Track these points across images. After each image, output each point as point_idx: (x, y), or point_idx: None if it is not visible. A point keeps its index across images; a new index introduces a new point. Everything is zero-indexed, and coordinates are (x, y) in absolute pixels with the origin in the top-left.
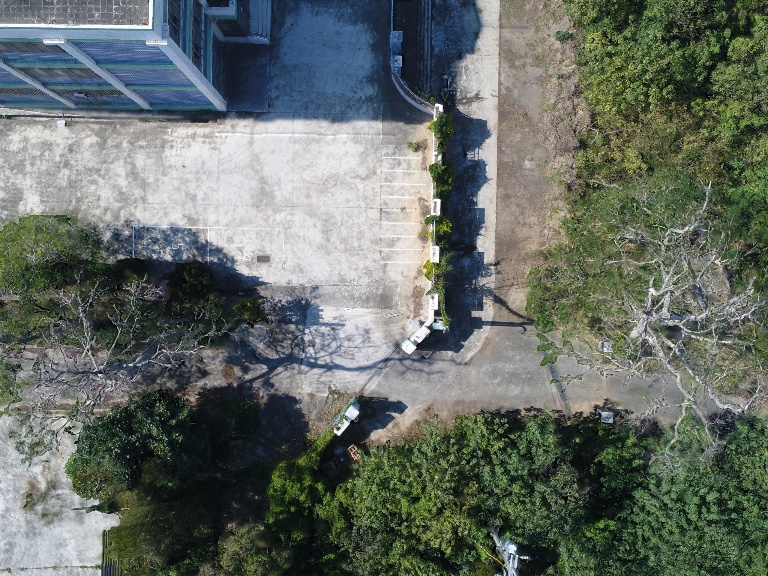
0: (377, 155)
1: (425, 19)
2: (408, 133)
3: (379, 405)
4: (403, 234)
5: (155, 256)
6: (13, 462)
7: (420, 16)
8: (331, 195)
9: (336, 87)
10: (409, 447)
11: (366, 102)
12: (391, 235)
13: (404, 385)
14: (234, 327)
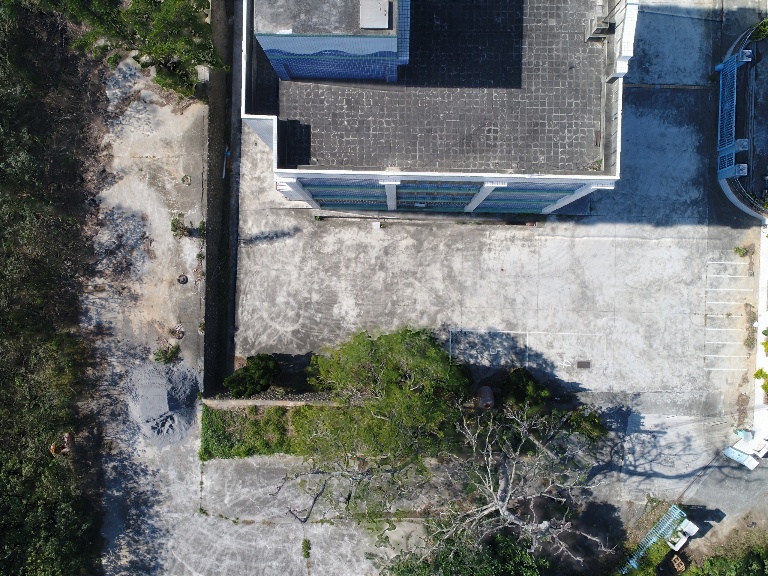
0: (702, 260)
1: (749, 119)
2: (735, 237)
3: (697, 513)
4: (728, 341)
5: (472, 361)
6: (335, 571)
7: (746, 117)
8: (654, 300)
9: (660, 190)
10: (760, 568)
11: (691, 205)
12: (716, 342)
13: (722, 493)
14: (554, 434)
